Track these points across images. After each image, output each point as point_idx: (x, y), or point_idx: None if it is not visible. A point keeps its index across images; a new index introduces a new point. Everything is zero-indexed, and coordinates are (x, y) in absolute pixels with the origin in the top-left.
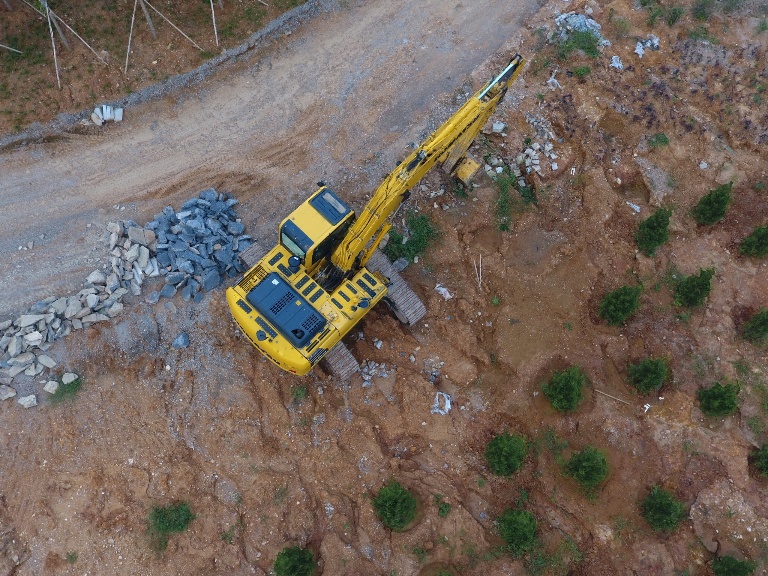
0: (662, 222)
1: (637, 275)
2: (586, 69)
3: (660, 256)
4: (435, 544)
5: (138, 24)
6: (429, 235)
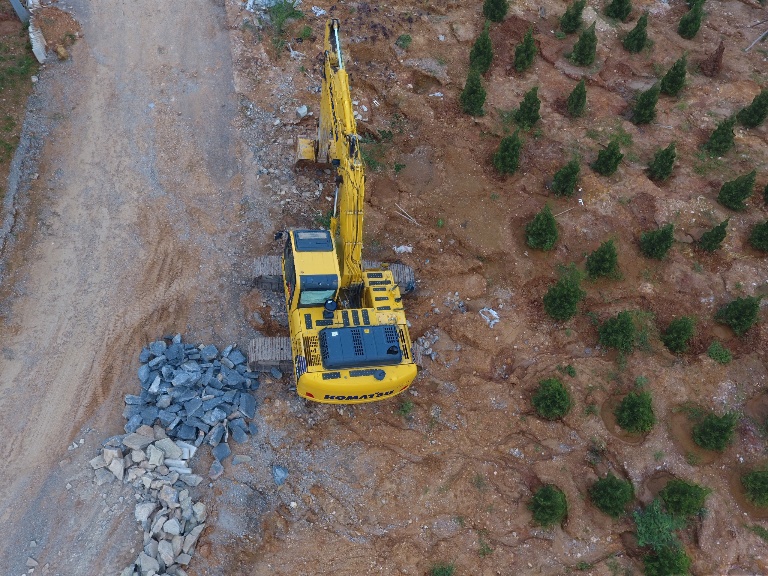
0: (477, 83)
1: (490, 132)
2: (308, 29)
3: (488, 110)
4: None
5: None
6: None
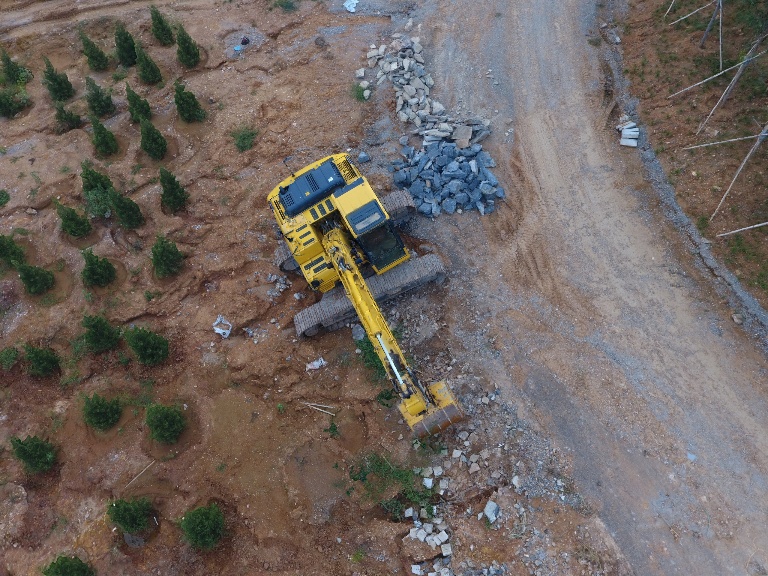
0: None
1: None
2: None
3: None
4: (135, 284)
5: (761, 164)
6: (376, 369)
